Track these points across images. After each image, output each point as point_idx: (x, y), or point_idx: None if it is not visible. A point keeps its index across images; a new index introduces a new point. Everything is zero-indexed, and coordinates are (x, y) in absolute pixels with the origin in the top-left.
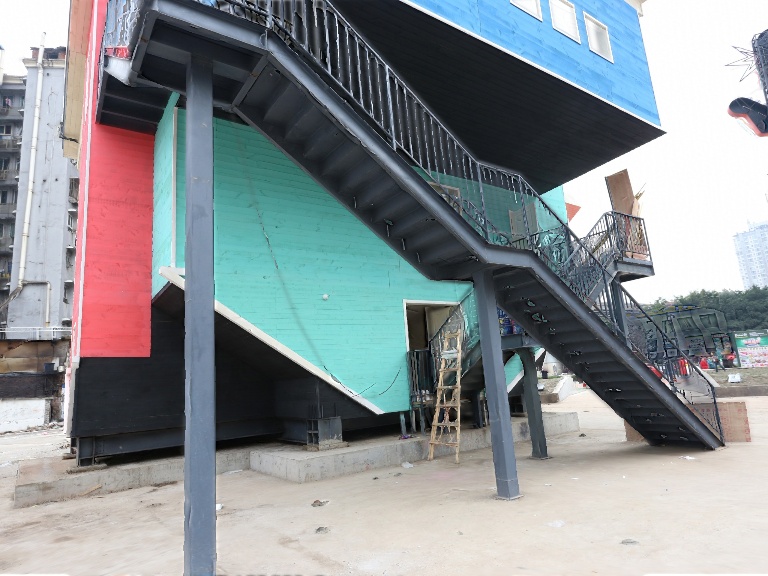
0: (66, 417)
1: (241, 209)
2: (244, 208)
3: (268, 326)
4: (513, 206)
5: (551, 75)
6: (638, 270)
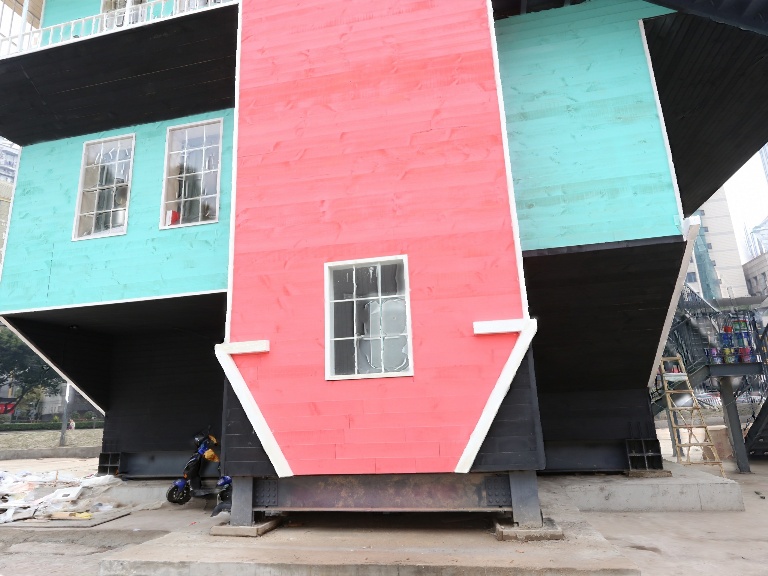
0: (274, 441)
1: None
2: None
3: None
4: None
5: None
6: None
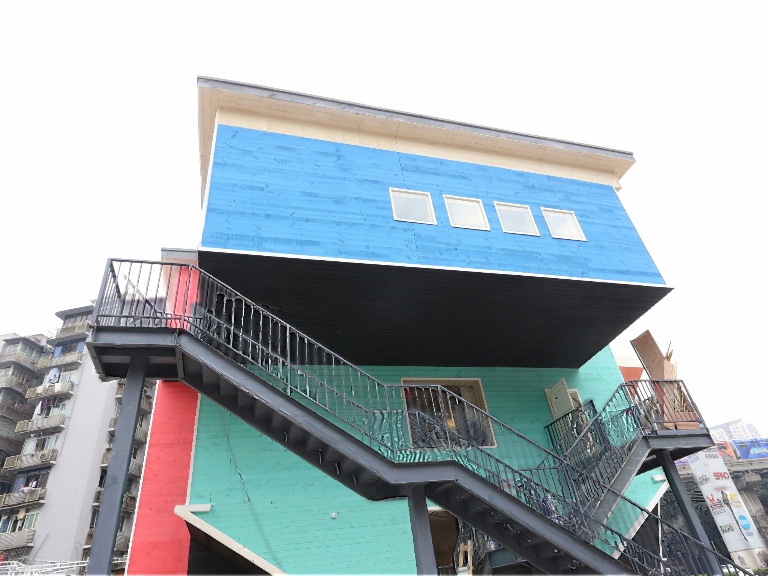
0: None
1: (253, 439)
2: (256, 438)
3: (273, 554)
4: (550, 384)
5: (502, 274)
6: (687, 442)
